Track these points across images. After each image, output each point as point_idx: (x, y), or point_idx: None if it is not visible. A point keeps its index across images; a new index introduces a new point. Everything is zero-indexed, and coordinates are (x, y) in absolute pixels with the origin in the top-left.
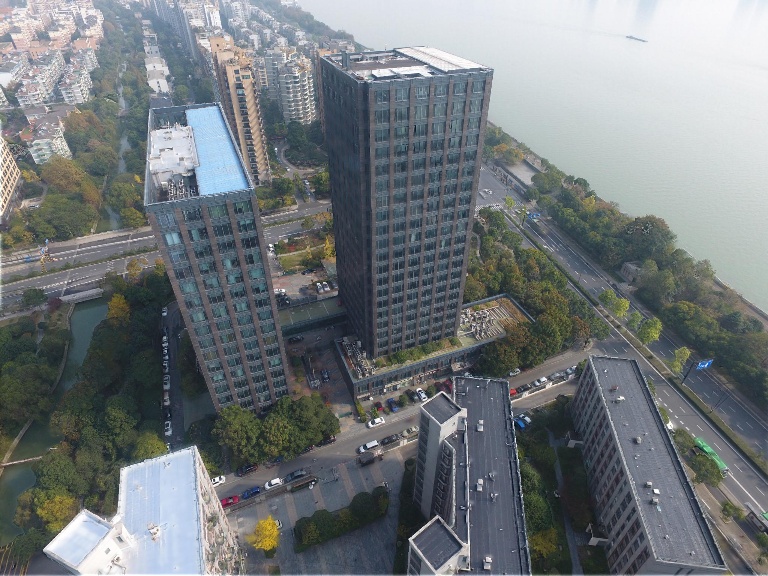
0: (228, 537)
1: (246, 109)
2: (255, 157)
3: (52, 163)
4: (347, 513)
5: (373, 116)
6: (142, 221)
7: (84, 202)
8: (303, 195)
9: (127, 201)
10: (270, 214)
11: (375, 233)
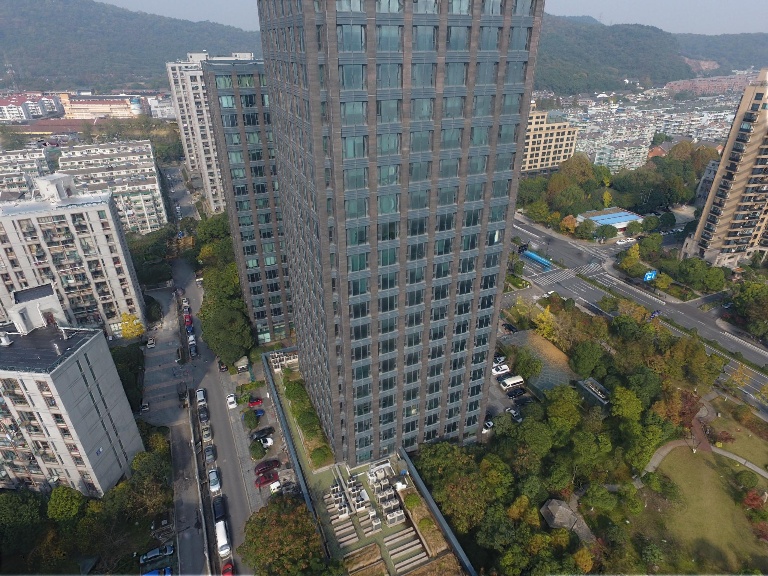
0: (115, 291)
1: (740, 152)
2: (714, 224)
3: (572, 157)
4: (118, 368)
5: (259, 8)
6: (541, 219)
7: (546, 190)
8: (715, 301)
9: (562, 202)
10: (634, 285)
11: (280, 186)
